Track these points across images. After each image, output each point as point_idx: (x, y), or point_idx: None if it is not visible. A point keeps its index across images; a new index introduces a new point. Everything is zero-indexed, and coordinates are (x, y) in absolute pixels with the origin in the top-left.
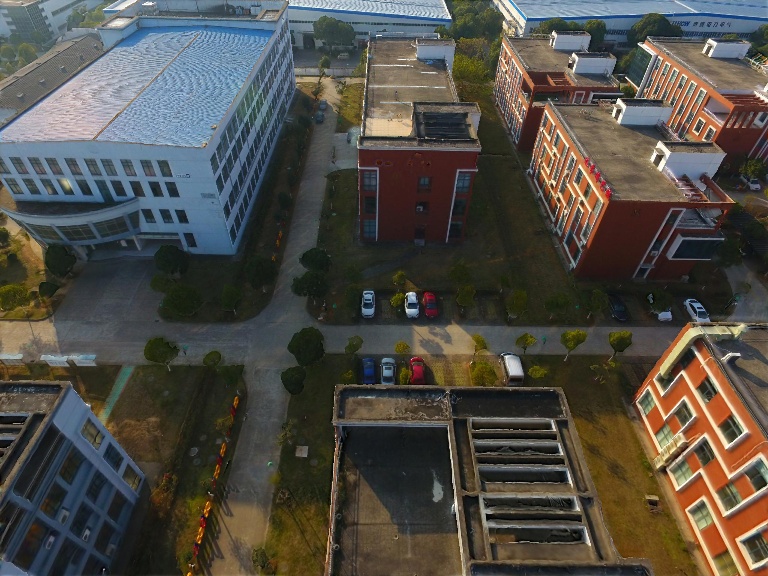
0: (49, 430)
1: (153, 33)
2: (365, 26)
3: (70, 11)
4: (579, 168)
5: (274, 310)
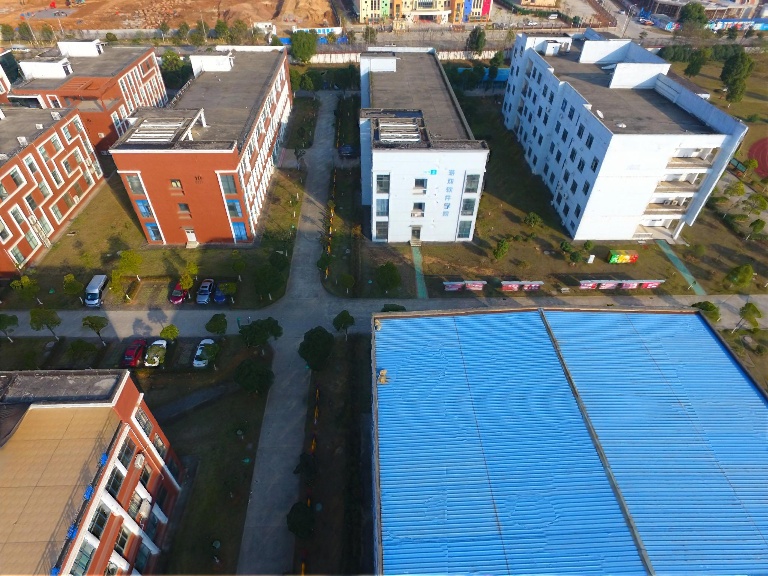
0: None
1: None
2: None
3: None
4: None
5: None
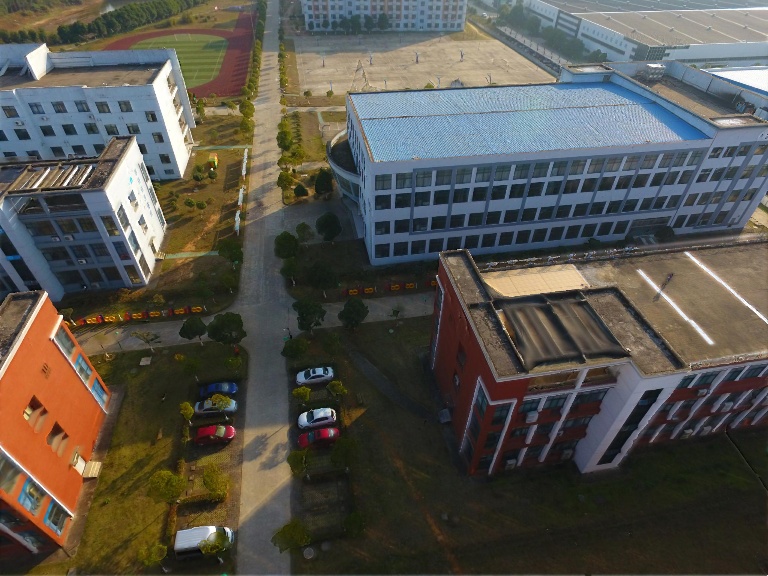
0: (76, 195)
1: (602, 88)
2: None
3: None
4: None
5: None
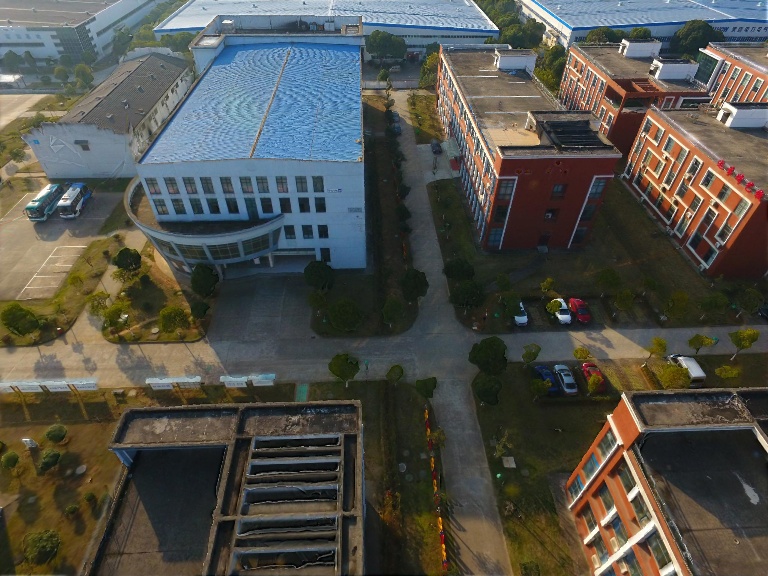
0: None
1: (242, 51)
2: (414, 39)
3: (111, 31)
4: (709, 171)
5: (425, 322)
